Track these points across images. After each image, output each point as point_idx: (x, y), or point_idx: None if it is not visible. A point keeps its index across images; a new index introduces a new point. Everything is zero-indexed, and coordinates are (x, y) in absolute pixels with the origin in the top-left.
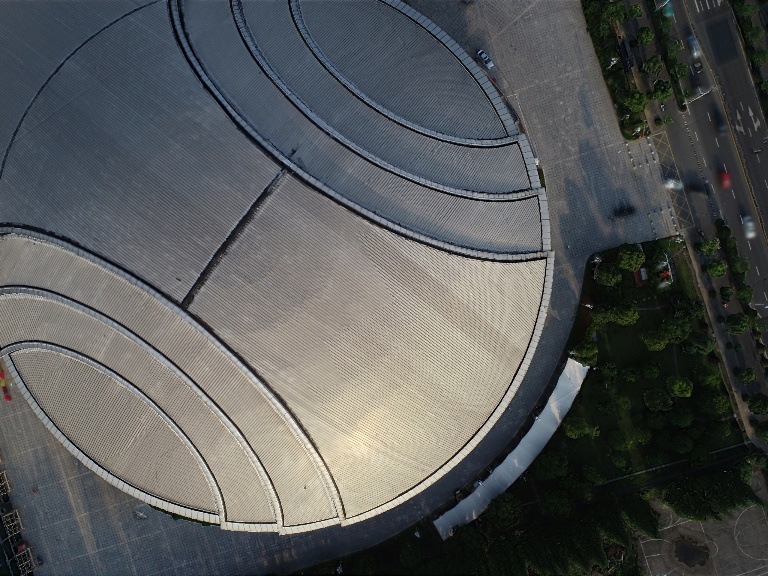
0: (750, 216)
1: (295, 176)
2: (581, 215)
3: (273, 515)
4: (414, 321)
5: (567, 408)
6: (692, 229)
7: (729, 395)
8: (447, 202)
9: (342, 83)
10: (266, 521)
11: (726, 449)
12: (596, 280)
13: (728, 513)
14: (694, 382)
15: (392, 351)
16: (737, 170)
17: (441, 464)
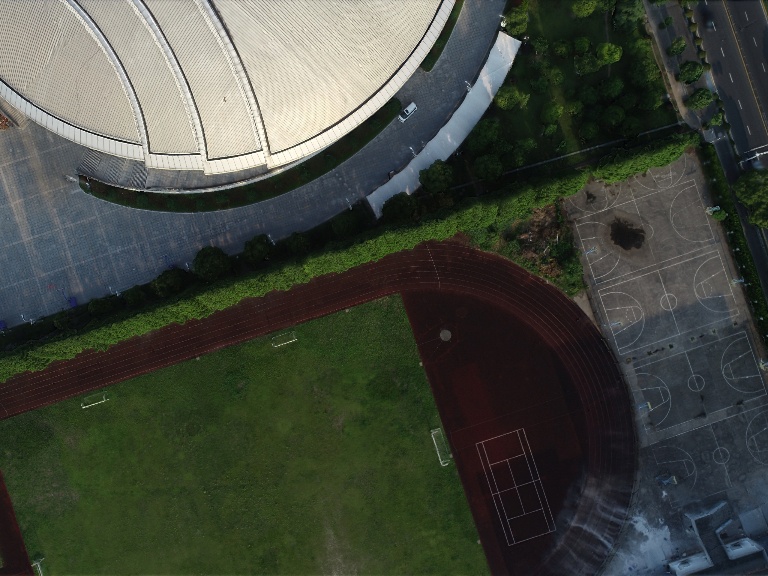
0: None
1: None
2: None
3: (196, 143)
4: None
5: (499, 84)
6: None
7: (662, 75)
8: None
9: None
10: (189, 152)
11: (660, 129)
12: None
13: None
14: (625, 54)
15: None
16: None
17: (365, 98)
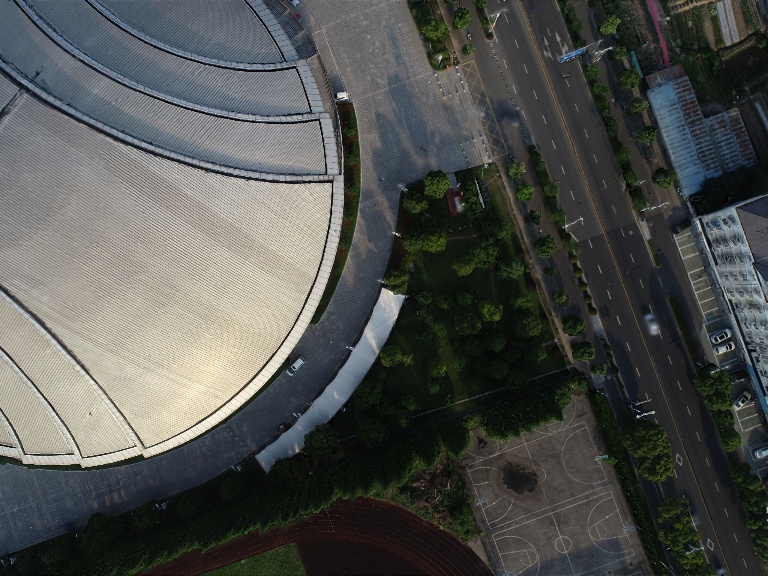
0: (562, 141)
1: (33, 95)
2: (393, 147)
3: (69, 446)
4: (171, 238)
5: (384, 338)
6: (505, 156)
7: (549, 320)
8: (205, 122)
9: (97, 9)
10: (63, 452)
11: (548, 374)
12: (405, 209)
13: (530, 430)
14: (508, 307)
15: (150, 269)
16: (547, 95)
17: (237, 390)
